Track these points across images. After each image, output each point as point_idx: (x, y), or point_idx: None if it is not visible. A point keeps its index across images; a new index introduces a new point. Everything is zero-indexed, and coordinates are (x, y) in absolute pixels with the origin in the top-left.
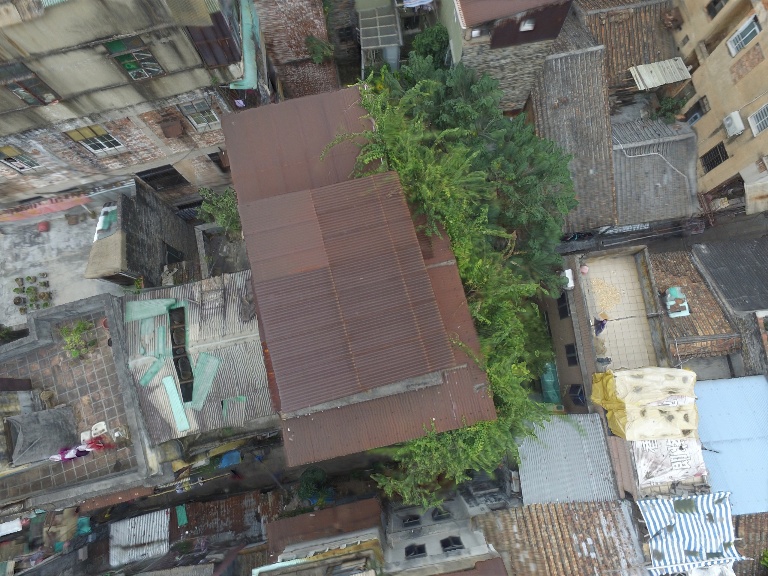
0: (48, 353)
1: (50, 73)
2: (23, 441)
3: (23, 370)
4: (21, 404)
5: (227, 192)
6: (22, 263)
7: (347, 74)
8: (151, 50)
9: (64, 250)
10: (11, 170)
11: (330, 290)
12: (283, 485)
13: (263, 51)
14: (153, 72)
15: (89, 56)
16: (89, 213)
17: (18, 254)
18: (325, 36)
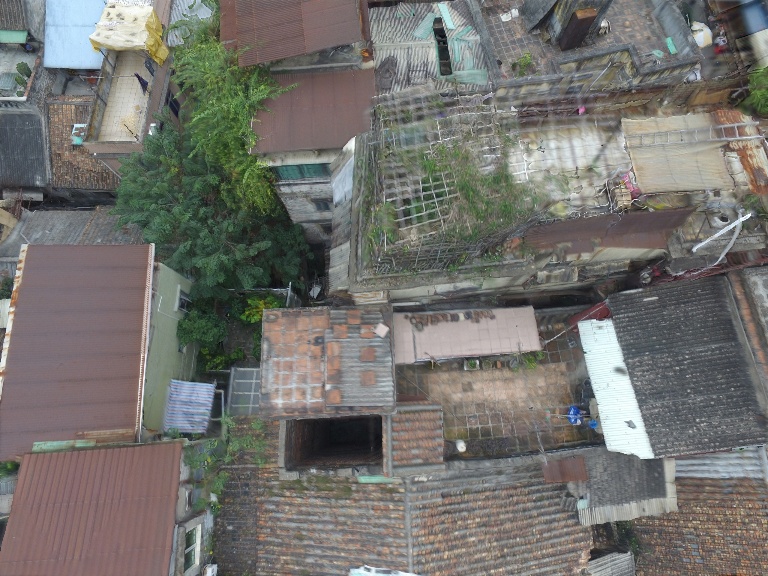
0: None
1: None
2: None
3: None
4: (558, 22)
5: None
6: None
7: None
8: None
9: None
10: None
11: None
12: None
13: None
14: None
15: None
16: None
17: None
18: None
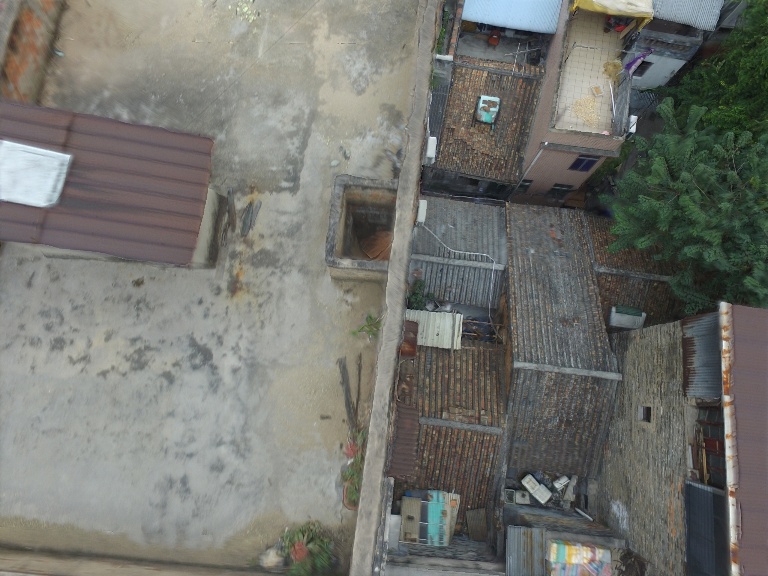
0: None
1: None
2: None
3: None
4: None
5: None
6: None
7: None
8: None
9: None
10: None
11: None
12: None
13: None
14: None
15: None
16: None
17: None
18: None
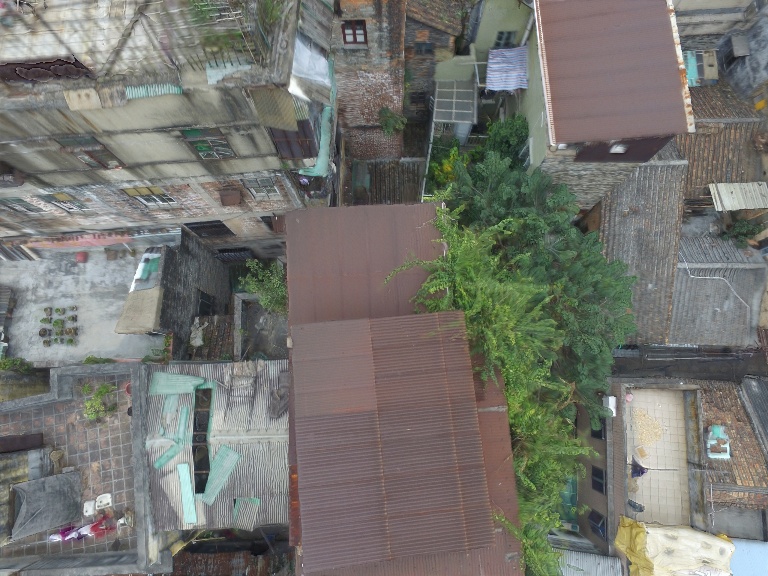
0: (65, 409)
1: (119, 146)
2: (26, 512)
3: (37, 422)
4: (30, 466)
5: (274, 266)
6: (54, 291)
7: (412, 136)
8: (227, 139)
9: (98, 285)
10: (60, 210)
11: (374, 438)
12: (275, 549)
13: (335, 119)
14: (224, 155)
15: (163, 137)
16: (129, 251)
17: (51, 281)
18: (400, 110)
